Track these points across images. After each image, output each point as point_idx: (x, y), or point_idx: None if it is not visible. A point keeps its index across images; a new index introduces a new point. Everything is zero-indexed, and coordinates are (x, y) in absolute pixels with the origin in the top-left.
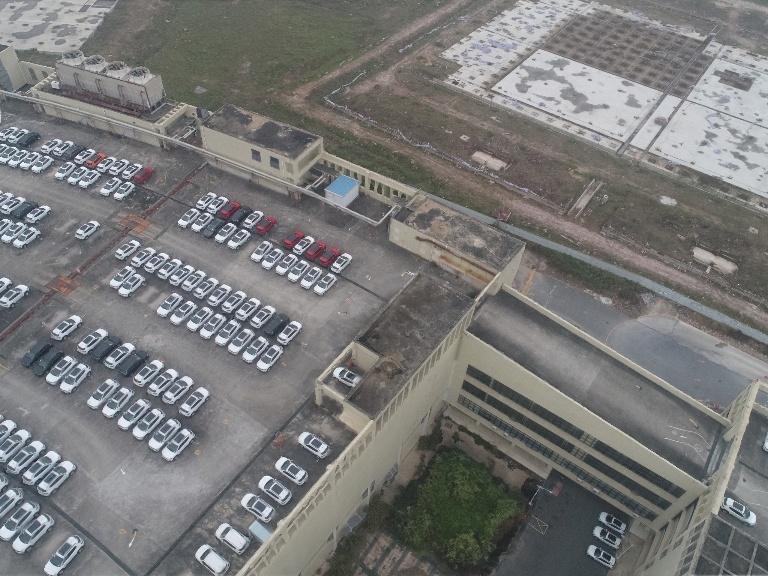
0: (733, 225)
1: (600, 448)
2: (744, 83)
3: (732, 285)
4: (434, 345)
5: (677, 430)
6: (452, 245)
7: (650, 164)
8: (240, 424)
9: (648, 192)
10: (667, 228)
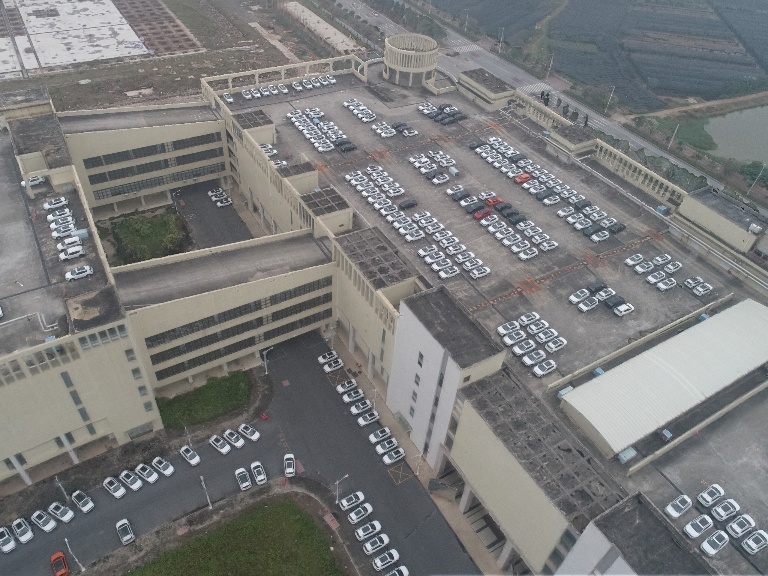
0: (130, 74)
1: (177, 147)
2: (52, 13)
3: (159, 95)
4: (60, 134)
5: (195, 116)
6: (7, 106)
7: (52, 72)
8: (3, 229)
9: (68, 84)
10: (100, 92)
